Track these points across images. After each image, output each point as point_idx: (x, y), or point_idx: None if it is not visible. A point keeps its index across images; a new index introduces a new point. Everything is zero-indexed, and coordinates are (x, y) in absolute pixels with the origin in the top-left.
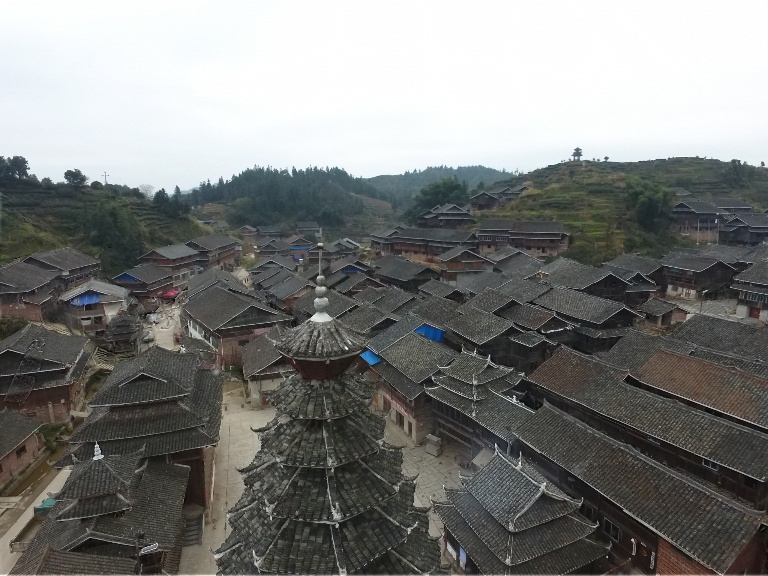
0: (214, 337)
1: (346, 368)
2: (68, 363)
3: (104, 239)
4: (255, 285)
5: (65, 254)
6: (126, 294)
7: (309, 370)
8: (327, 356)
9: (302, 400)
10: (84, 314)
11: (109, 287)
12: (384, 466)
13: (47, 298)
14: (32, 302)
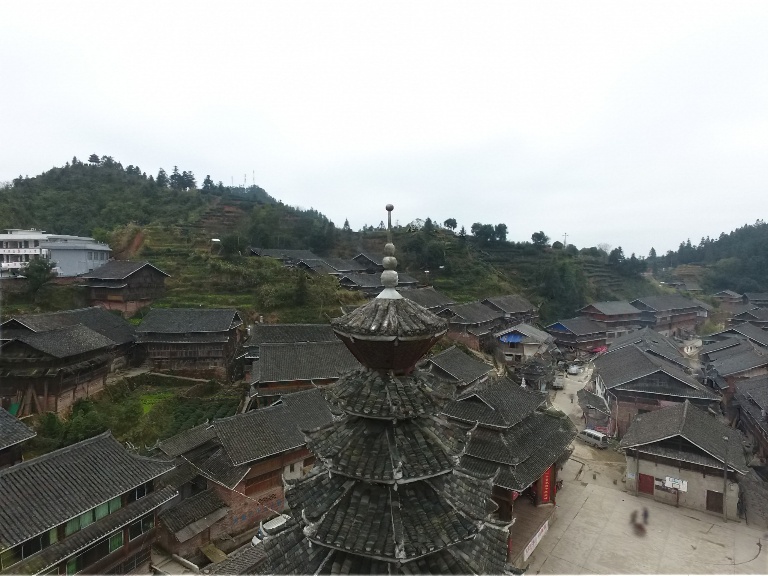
0: (610, 397)
1: (392, 361)
2: (464, 381)
3: (550, 291)
4: (700, 356)
5: (512, 300)
6: (549, 340)
7: (354, 351)
8: (349, 331)
9: (341, 383)
10: (508, 350)
11: (534, 331)
12: (425, 522)
13: (485, 332)
14: (473, 333)
